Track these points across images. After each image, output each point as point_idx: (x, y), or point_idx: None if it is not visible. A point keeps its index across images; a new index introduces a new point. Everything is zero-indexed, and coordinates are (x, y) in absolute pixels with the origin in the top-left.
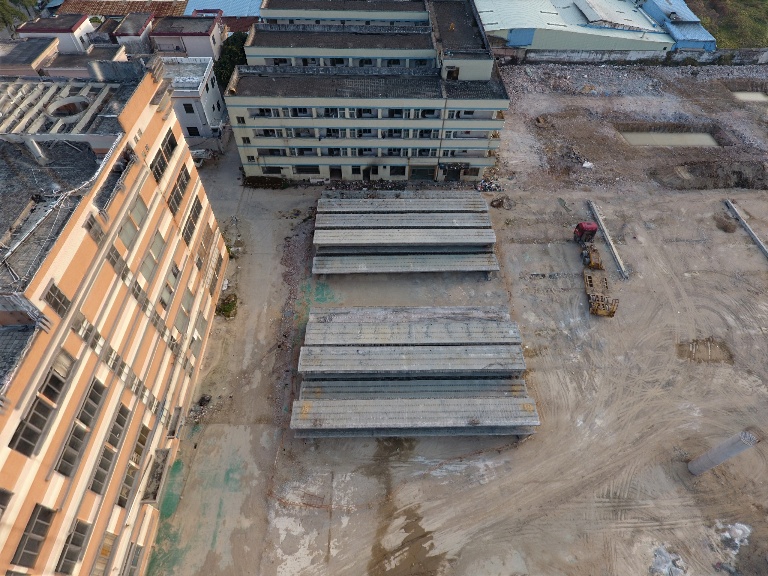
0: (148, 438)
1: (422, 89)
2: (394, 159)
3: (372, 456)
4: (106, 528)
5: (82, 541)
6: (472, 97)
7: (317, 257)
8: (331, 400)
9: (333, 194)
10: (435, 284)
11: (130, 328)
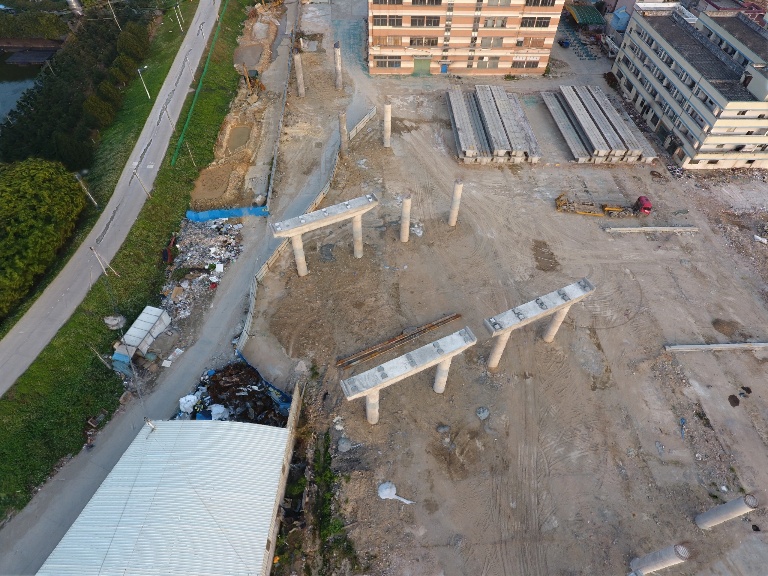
0: (434, 46)
1: (715, 73)
2: None
3: (441, 118)
4: (402, 35)
5: (397, 25)
6: (724, 92)
7: None
8: None
9: (612, 96)
10: (555, 140)
11: (465, 5)
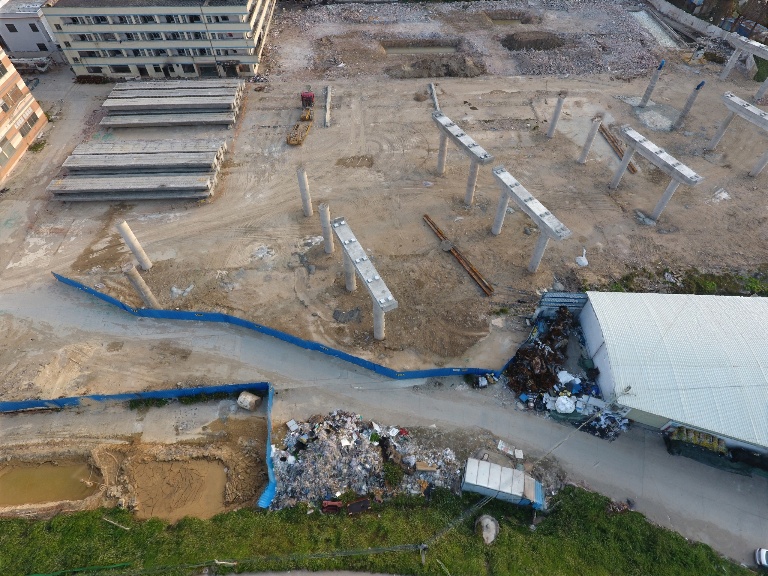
0: None
1: (191, 3)
2: (182, 58)
3: (104, 212)
4: None
5: None
6: None
7: (106, 116)
8: (77, 179)
9: None
10: (189, 132)
11: None
